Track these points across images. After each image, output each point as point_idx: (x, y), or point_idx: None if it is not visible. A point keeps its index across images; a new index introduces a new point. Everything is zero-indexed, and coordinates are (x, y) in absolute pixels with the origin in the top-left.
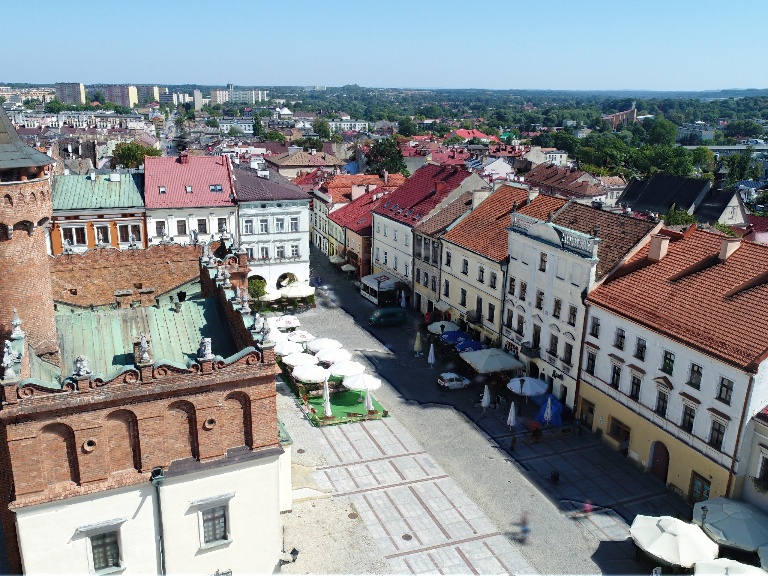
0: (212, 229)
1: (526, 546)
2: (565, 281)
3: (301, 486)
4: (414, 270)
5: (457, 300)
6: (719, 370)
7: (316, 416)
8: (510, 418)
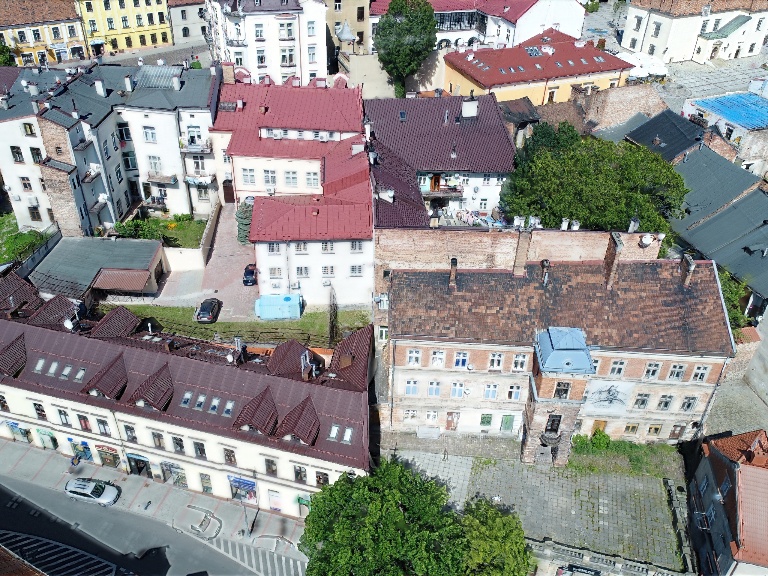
0: None
1: None
2: None
3: None
4: None
5: None
6: None
7: None
8: None
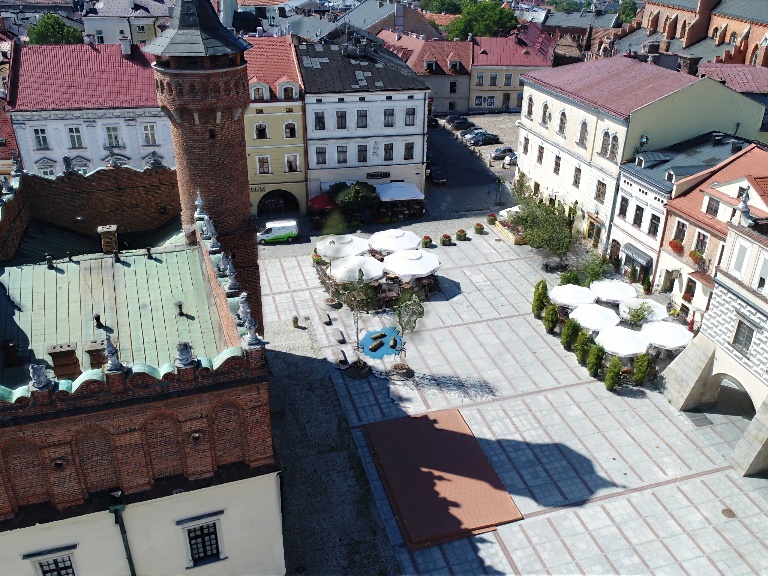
0: None
1: None
2: None
3: None
4: None
5: None
6: None
7: None
8: None
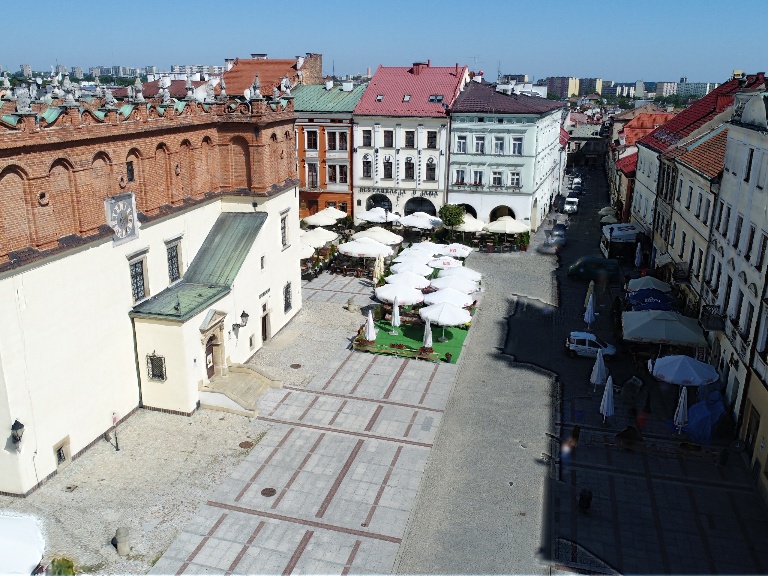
0: (420, 143)
1: (412, 575)
2: (763, 191)
3: (217, 390)
4: (656, 214)
5: (677, 250)
6: None
7: (356, 337)
8: (603, 402)
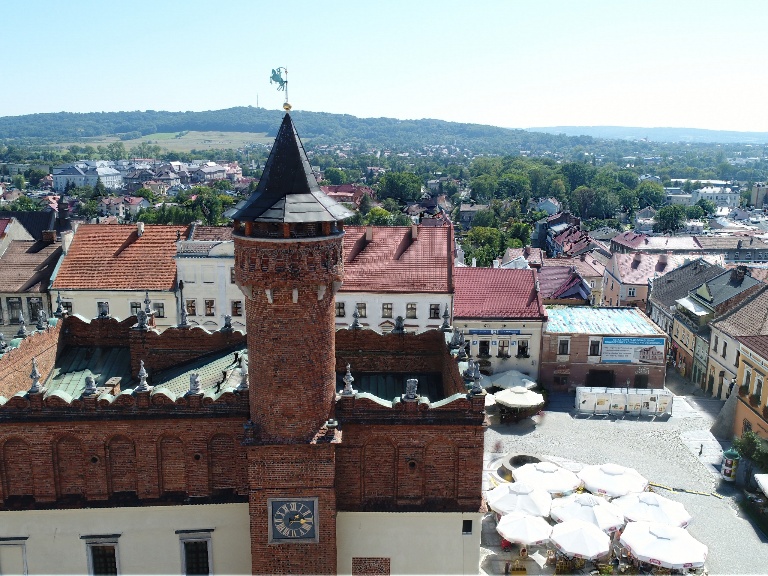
0: None
1: None
2: None
3: None
4: None
5: None
6: (429, 301)
7: None
8: None
